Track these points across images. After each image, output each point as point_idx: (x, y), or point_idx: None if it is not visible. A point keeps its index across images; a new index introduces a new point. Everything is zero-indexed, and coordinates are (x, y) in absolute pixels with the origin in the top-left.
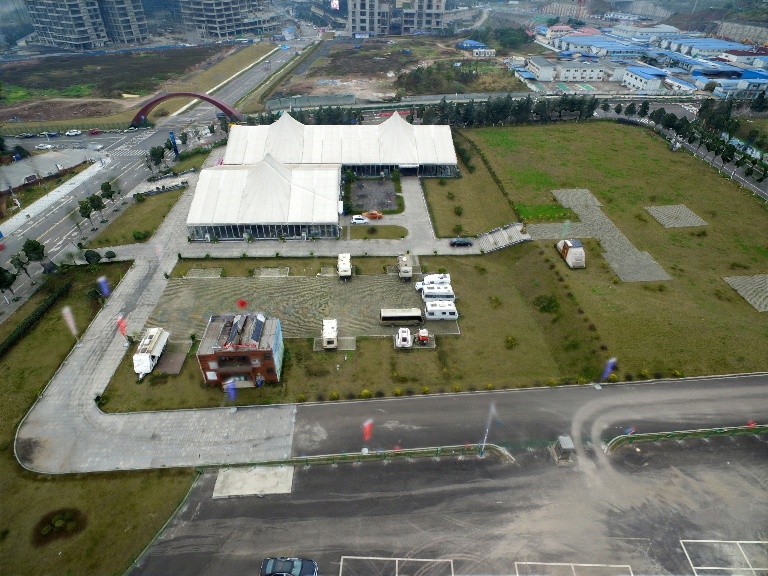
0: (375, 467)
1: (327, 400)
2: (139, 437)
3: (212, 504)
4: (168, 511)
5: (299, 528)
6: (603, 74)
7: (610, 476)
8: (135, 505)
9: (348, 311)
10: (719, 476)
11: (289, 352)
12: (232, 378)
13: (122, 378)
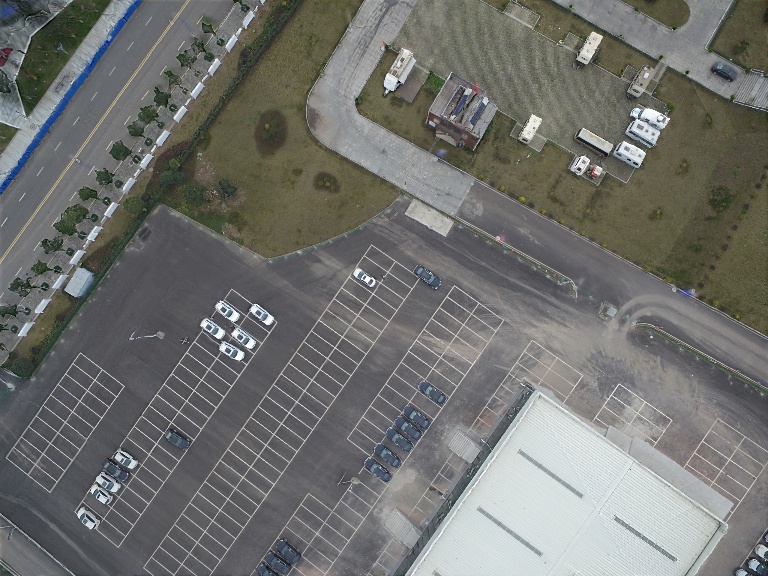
0: (498, 251)
1: (496, 188)
2: (375, 147)
3: (403, 217)
4: (380, 208)
5: (441, 259)
6: None
7: (619, 338)
8: (365, 194)
9: (558, 107)
10: (678, 377)
11: (492, 126)
12: (444, 132)
13: (374, 85)
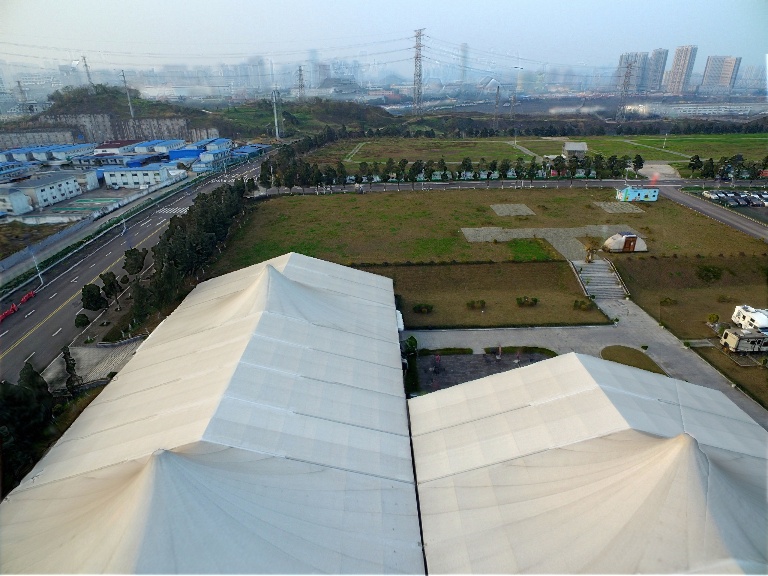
0: None
1: None
2: None
3: None
4: None
5: None
6: (77, 184)
7: None
8: None
9: None
10: None
11: None
12: None
13: None
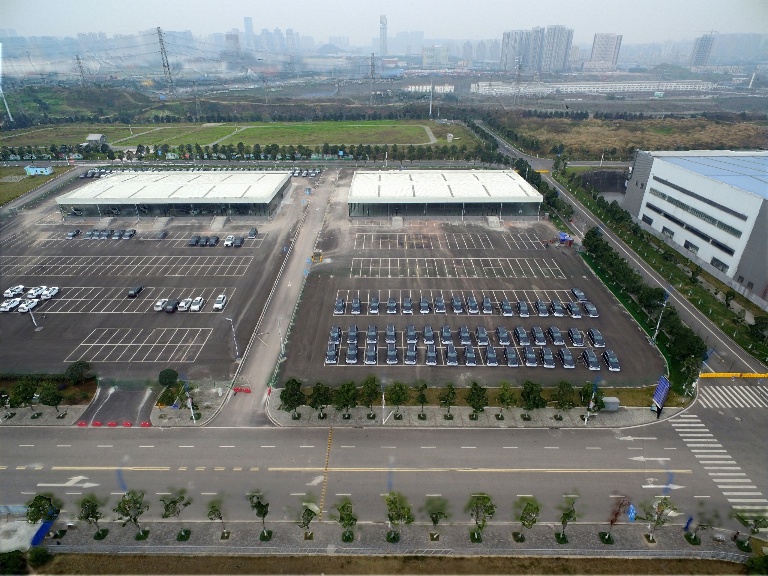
0: None
1: None
2: None
3: None
4: None
5: None
6: None
7: None
8: None
9: None
10: (53, 199)
11: None
12: None
13: None
